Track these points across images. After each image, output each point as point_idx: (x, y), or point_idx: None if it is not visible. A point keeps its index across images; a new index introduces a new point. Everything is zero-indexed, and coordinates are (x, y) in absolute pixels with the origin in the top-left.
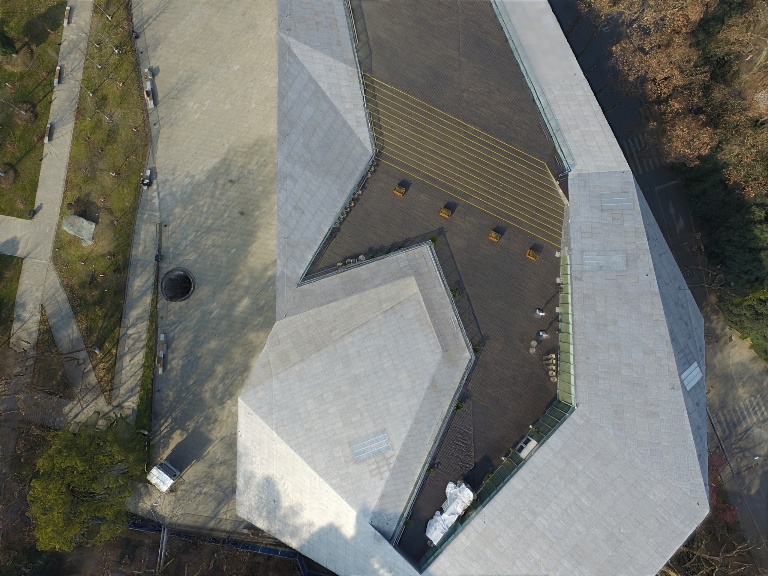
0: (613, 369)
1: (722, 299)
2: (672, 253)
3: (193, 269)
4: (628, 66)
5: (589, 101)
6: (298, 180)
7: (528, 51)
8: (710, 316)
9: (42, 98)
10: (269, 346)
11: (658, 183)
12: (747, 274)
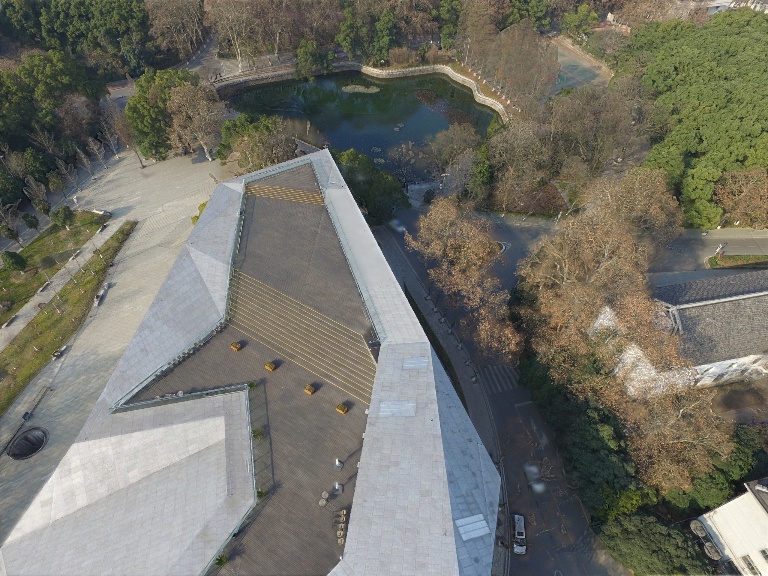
0: (388, 512)
1: (593, 519)
2: (539, 469)
3: (53, 430)
4: (441, 283)
5: (399, 295)
6: (155, 331)
7: (360, 266)
8: (596, 549)
9: (23, 299)
10: (58, 476)
11: (517, 401)
12: (595, 477)
